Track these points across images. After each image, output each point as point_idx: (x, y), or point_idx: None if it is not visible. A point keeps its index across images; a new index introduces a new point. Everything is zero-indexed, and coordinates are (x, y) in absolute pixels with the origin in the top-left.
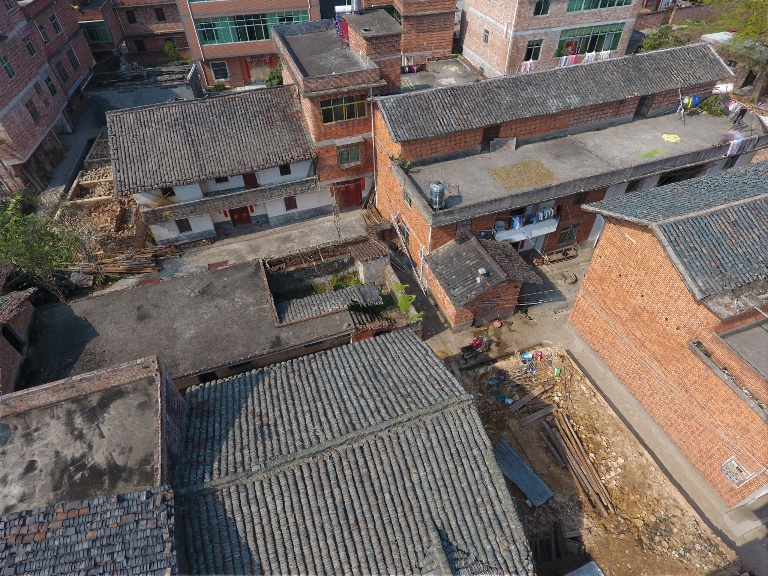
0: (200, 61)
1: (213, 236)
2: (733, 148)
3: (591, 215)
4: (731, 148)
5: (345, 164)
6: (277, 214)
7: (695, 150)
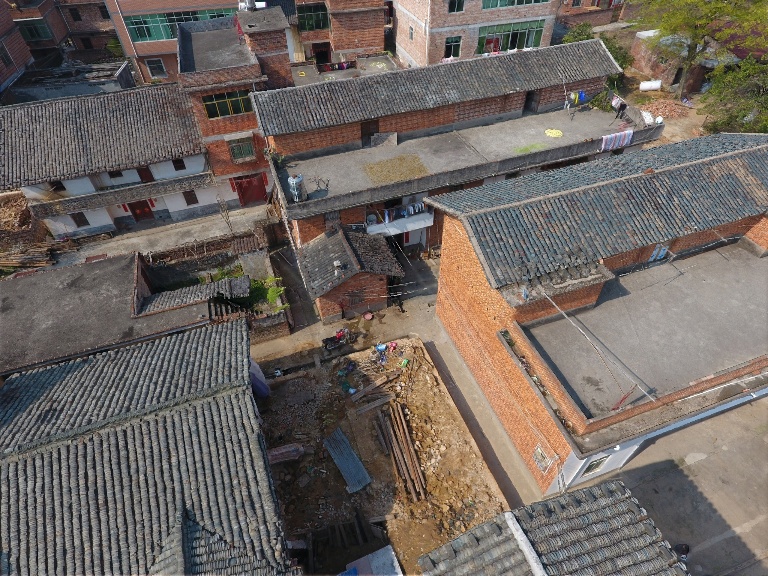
0: (135, 58)
1: (112, 230)
2: (607, 143)
3: None
4: (604, 143)
5: (239, 159)
6: (178, 209)
7: (566, 145)
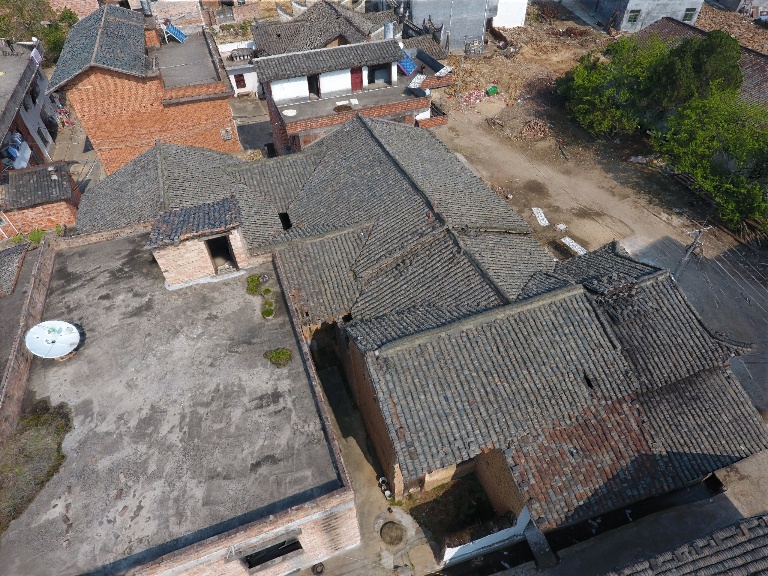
0: None
1: None
2: (36, 59)
3: (30, 136)
4: (35, 59)
5: None
6: None
7: None
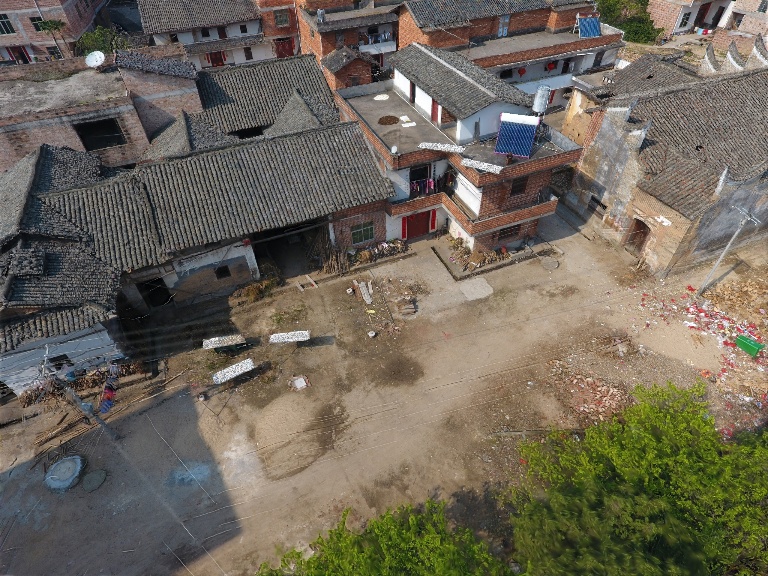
0: None
1: None
2: None
3: None
4: None
5: (279, 25)
6: (240, 62)
7: None
